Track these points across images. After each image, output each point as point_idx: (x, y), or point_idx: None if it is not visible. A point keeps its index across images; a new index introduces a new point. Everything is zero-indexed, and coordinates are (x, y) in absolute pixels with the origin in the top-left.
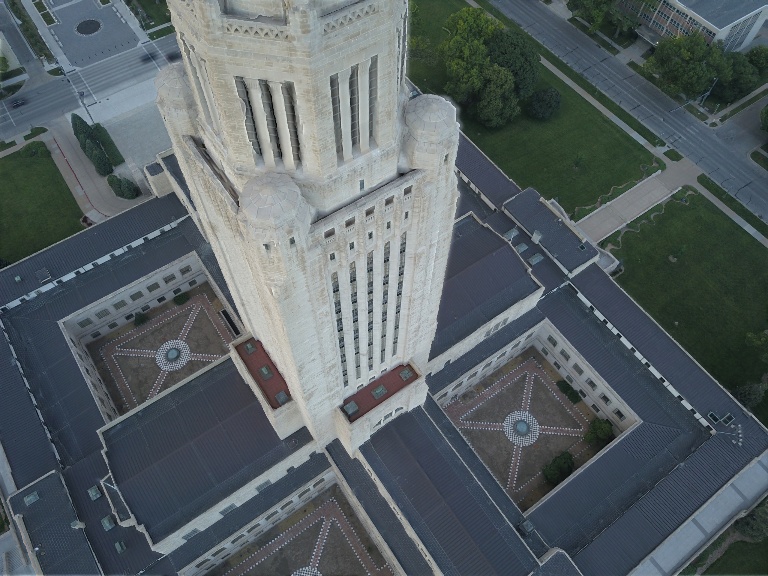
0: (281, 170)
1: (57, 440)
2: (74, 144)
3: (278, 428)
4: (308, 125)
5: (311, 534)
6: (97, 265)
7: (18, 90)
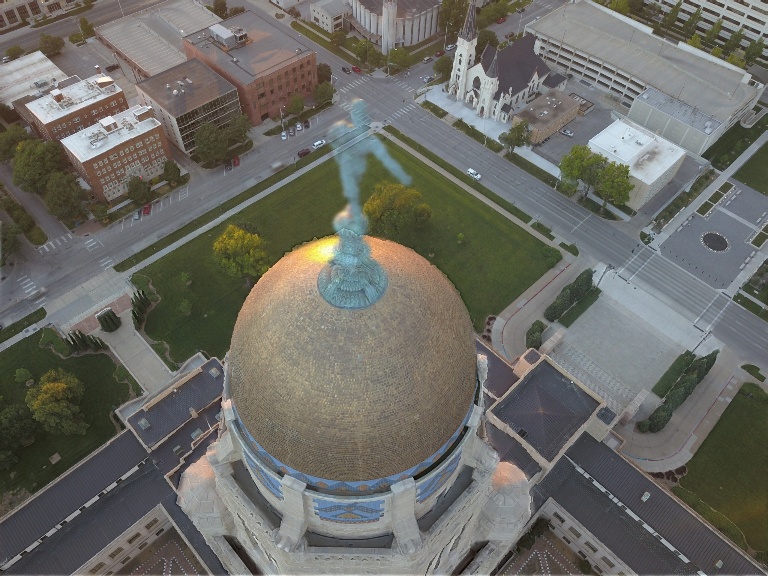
0: None
1: None
2: (571, 281)
3: None
4: None
5: None
6: None
7: (610, 219)
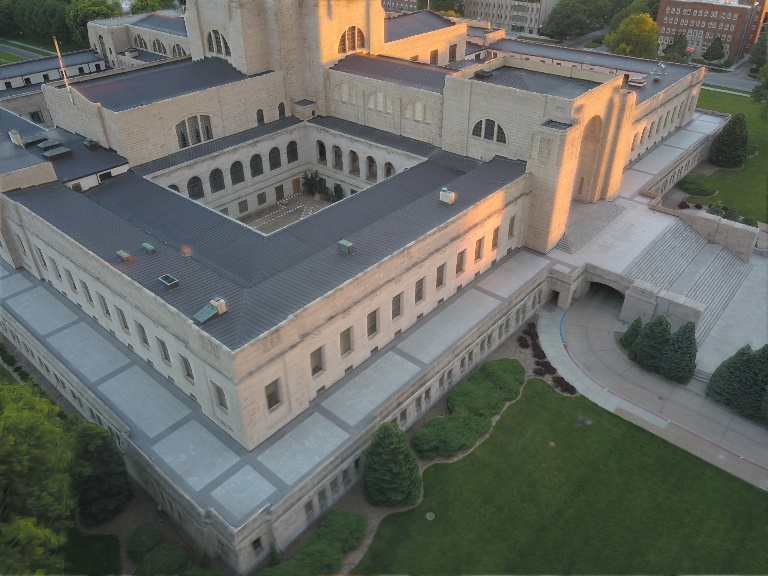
0: None
1: None
2: None
3: None
4: None
5: None
6: None
7: None
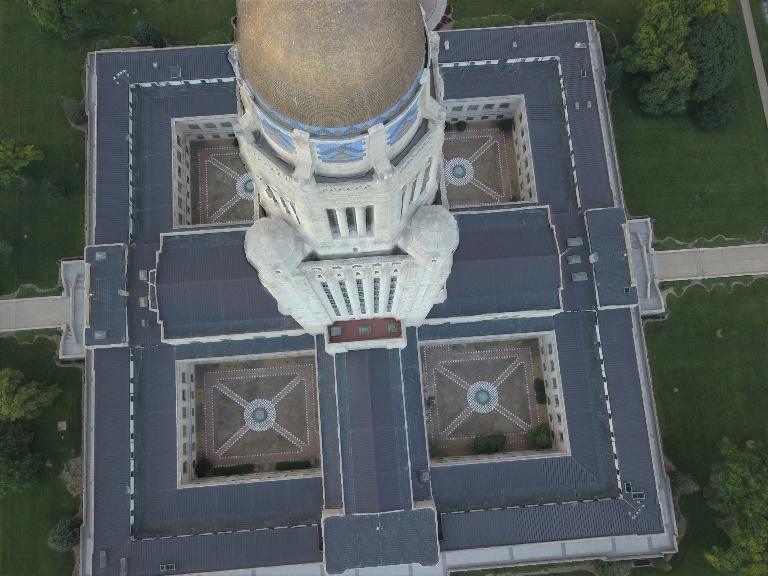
0: (291, 220)
1: (136, 217)
2: None
3: (281, 311)
4: (305, 222)
5: (283, 380)
6: (221, 81)
7: None
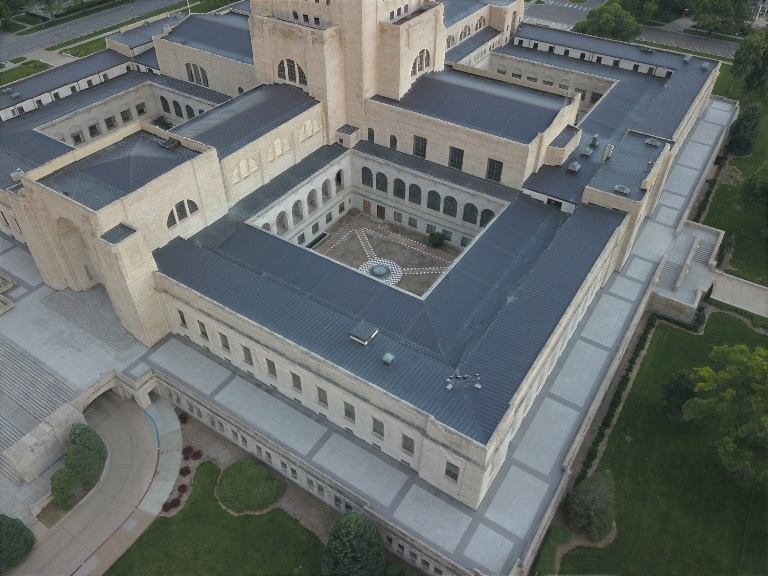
0: None
1: None
2: None
3: None
4: None
5: None
6: None
7: None
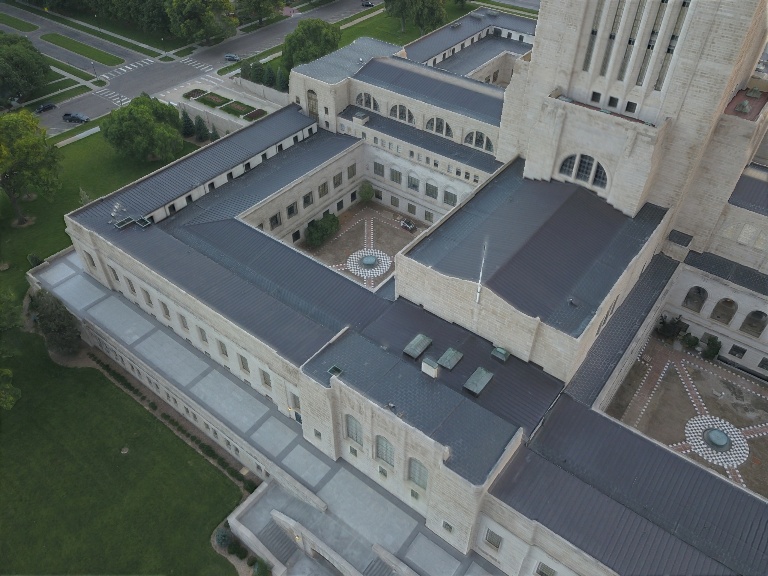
0: None
1: None
2: None
3: None
4: None
5: None
6: None
7: None
